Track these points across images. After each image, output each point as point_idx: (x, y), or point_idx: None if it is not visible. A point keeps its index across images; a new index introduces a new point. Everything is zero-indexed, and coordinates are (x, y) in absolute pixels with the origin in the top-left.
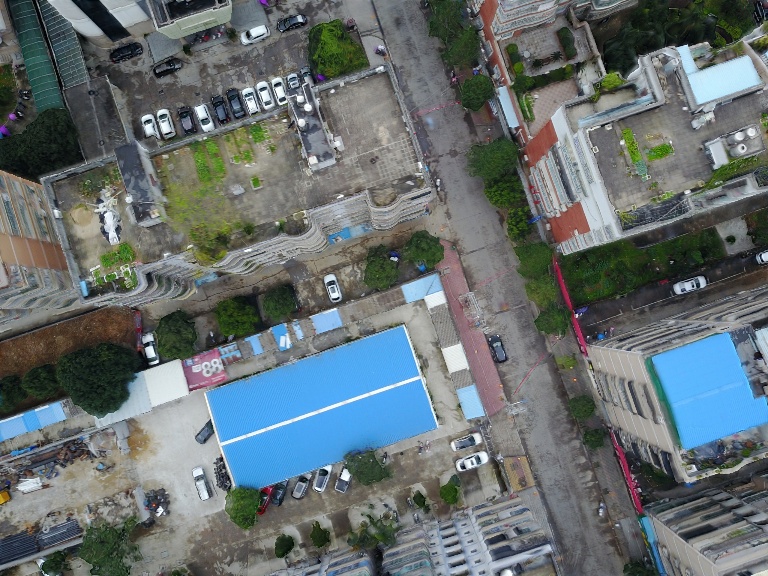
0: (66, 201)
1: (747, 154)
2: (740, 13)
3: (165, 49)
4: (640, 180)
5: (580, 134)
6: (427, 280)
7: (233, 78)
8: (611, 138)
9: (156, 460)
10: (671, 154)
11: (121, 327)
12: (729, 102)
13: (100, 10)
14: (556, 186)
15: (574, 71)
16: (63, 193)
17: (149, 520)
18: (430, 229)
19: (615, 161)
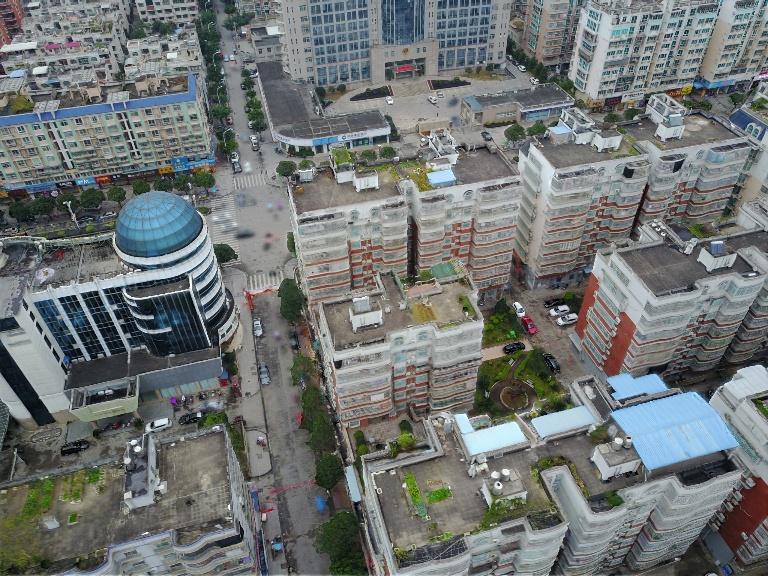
0: None
1: (509, 494)
2: None
3: (80, 434)
4: (420, 521)
5: None
6: None
7: None
8: (395, 482)
9: None
10: (450, 498)
11: None
12: (501, 456)
13: (33, 396)
14: None
15: None
16: None
17: None
18: None
19: (397, 502)
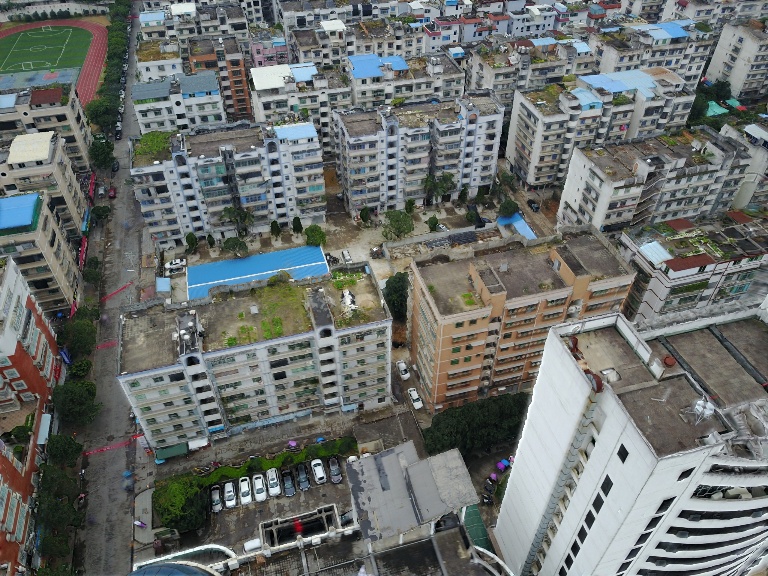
0: (379, 313)
1: None
2: None
3: None
4: None
5: (1, 307)
6: None
7: (288, 508)
8: None
9: (377, 271)
10: None
11: (399, 335)
12: None
13: None
14: (36, 339)
15: None
16: (381, 317)
17: (382, 246)
18: None
19: None
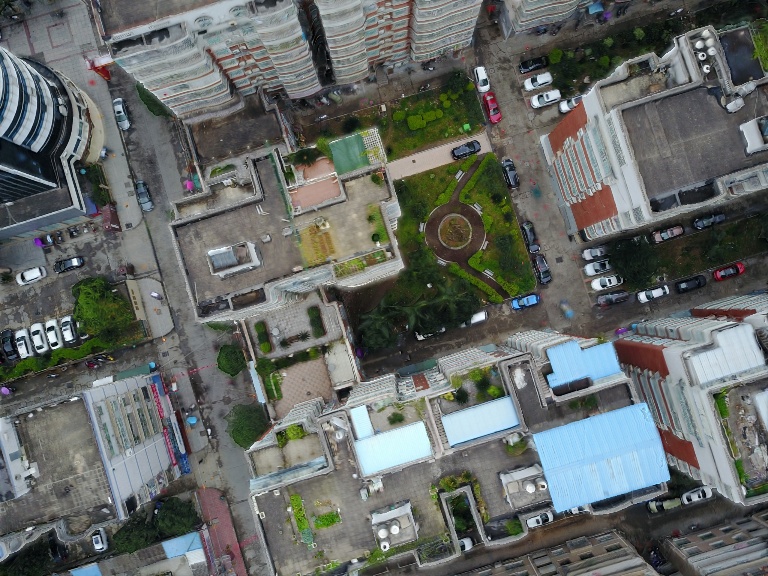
0: None
1: (398, 543)
2: (517, 270)
3: None
4: (306, 548)
5: None
6: (188, 537)
7: (9, 317)
8: (279, 503)
9: None
10: (338, 522)
11: None
12: (399, 470)
13: None
14: None
15: (320, 353)
16: None
17: None
18: (200, 478)
19: (282, 527)
